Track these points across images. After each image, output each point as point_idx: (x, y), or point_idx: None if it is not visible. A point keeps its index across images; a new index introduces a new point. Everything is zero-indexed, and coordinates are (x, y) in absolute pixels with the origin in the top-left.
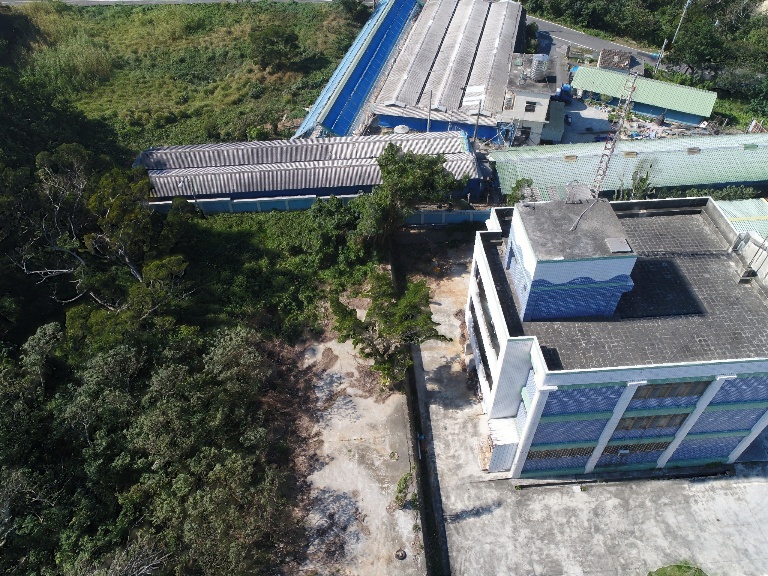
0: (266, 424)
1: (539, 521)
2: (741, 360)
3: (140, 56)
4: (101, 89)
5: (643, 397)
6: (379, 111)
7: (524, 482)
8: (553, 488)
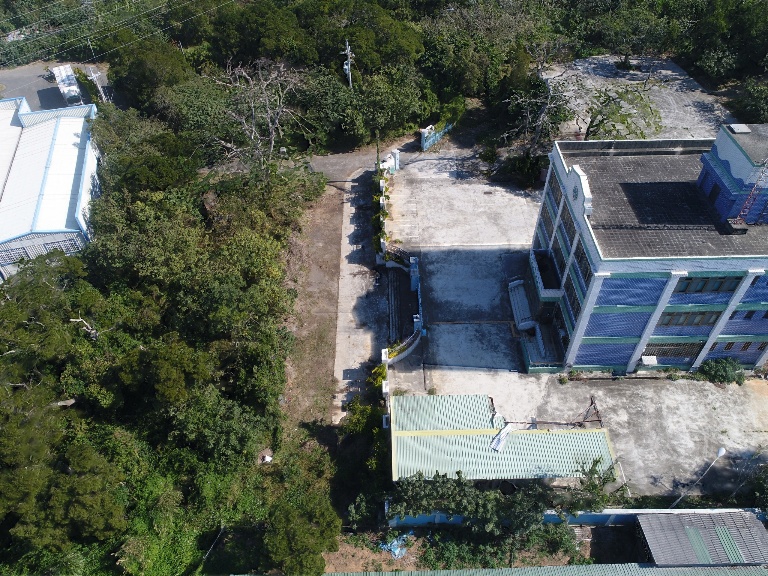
0: None
1: None
2: None
3: None
4: None
5: None
6: None
7: None
8: None
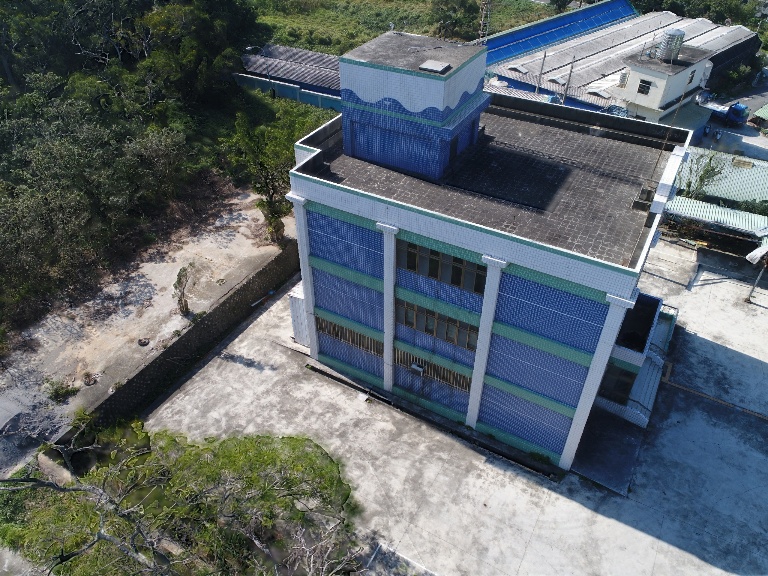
0: (155, 218)
1: (296, 398)
2: (507, 234)
3: (350, 6)
4: (297, 15)
5: (413, 269)
6: (498, 71)
7: (319, 365)
8: (340, 384)
